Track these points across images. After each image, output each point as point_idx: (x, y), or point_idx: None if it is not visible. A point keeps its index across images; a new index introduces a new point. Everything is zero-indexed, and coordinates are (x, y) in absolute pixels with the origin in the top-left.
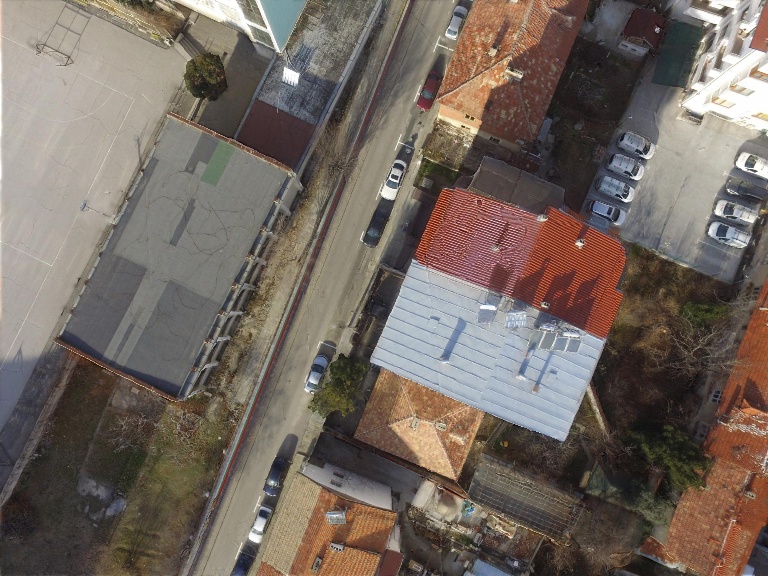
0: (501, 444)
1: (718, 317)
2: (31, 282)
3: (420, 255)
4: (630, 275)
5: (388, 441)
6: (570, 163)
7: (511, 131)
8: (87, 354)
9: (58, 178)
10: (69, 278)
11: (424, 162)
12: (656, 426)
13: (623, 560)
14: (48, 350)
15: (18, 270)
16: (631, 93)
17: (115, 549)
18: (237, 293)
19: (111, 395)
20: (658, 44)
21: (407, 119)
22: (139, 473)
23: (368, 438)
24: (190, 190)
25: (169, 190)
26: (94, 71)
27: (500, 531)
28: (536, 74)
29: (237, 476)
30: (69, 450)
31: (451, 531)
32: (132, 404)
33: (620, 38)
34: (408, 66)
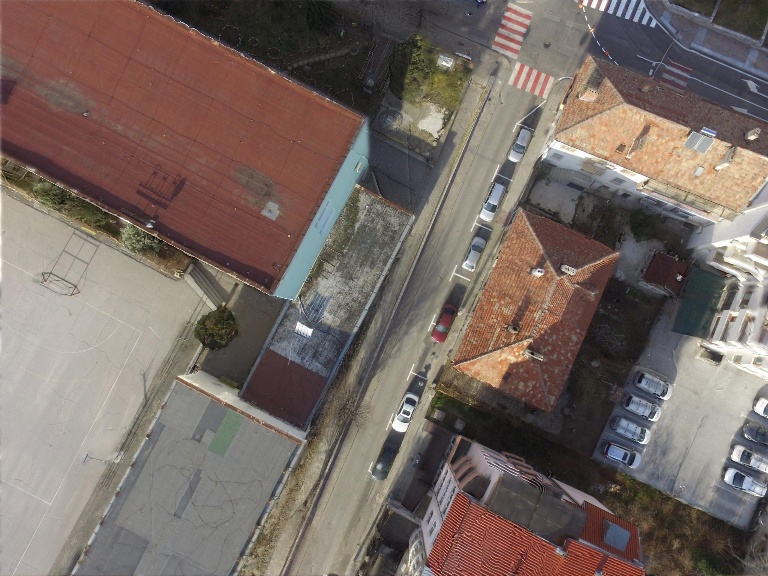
0: None
1: None
2: (28, 521)
3: (433, 562)
4: (644, 528)
5: None
6: (586, 399)
7: (529, 401)
8: None
9: (60, 412)
10: (68, 517)
11: (437, 394)
12: None
13: None
14: None
15: (15, 507)
16: (650, 331)
17: None
18: (242, 564)
19: None
20: (679, 292)
21: (420, 349)
22: None
23: None
24: (197, 460)
25: (175, 458)
26: (101, 302)
27: None
28: (556, 348)
29: None
30: None
31: None
32: None
33: (640, 275)
34: (423, 294)
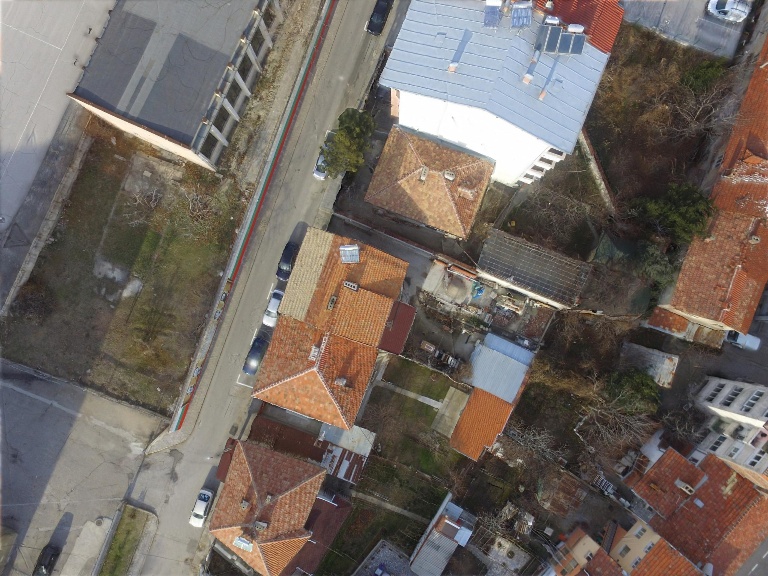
0: (508, 225)
1: (719, 75)
2: (42, 66)
3: None
4: (632, 45)
5: (398, 201)
6: None
7: None
8: (100, 106)
9: None
10: (79, 61)
11: None
12: (661, 189)
13: (631, 322)
14: (61, 132)
15: (28, 55)
16: None
17: (132, 329)
18: (246, 49)
19: (124, 180)
20: None
21: None
22: (154, 255)
23: (378, 199)
24: None
25: None
26: None
27: (510, 307)
28: None
29: (250, 264)
30: (84, 234)
31: (461, 313)
32: (145, 188)
33: None
34: None
